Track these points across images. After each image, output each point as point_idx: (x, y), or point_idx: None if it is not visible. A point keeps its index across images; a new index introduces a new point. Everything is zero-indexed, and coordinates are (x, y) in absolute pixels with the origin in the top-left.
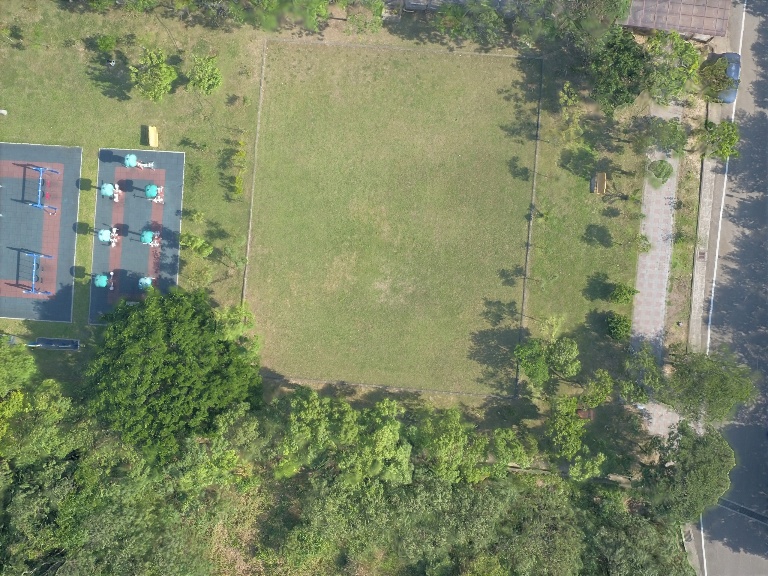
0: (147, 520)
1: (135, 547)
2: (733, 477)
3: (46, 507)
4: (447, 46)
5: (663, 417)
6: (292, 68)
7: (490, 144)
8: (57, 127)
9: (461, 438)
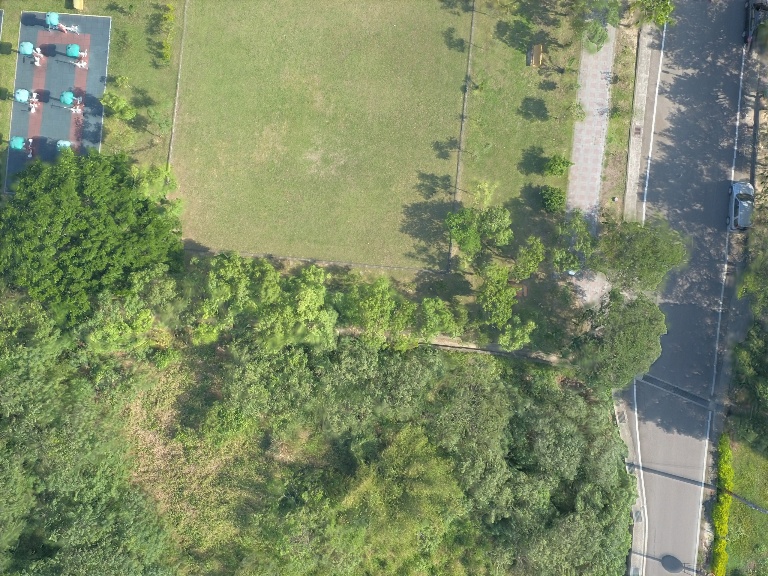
0: (57, 389)
1: (42, 413)
2: (667, 357)
3: None
4: None
5: (598, 295)
6: None
7: (426, 14)
8: None
9: (388, 302)
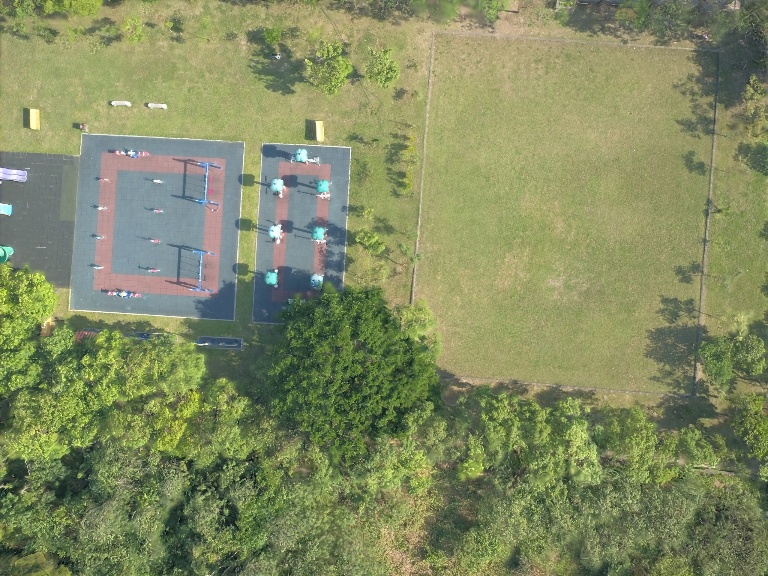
0: (325, 522)
1: (319, 550)
2: None
3: (225, 509)
4: (621, 39)
5: None
6: (461, 61)
7: (666, 138)
8: (219, 122)
9: (652, 437)
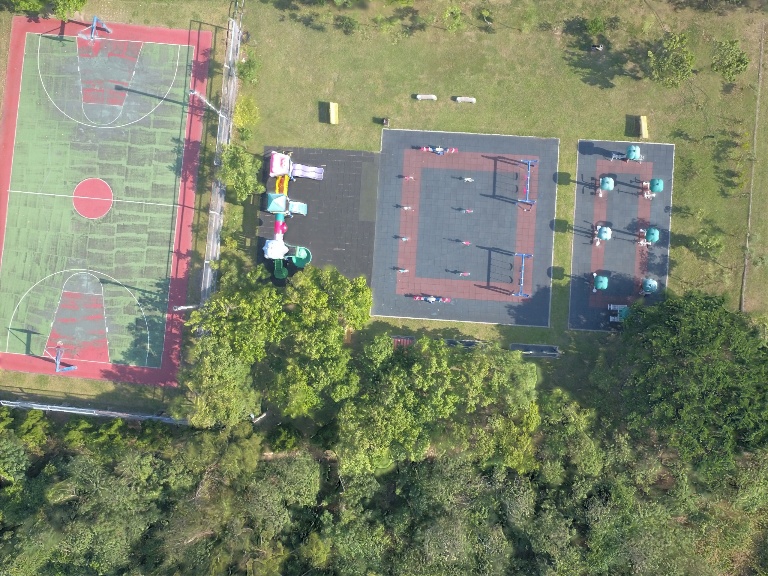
0: None
1: (677, 572)
2: None
3: (573, 528)
4: None
5: None
6: None
7: None
8: (532, 117)
9: None
